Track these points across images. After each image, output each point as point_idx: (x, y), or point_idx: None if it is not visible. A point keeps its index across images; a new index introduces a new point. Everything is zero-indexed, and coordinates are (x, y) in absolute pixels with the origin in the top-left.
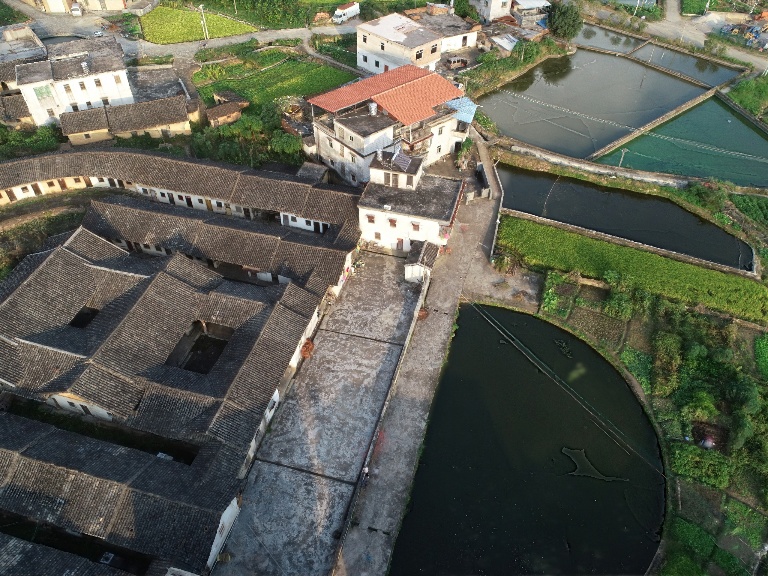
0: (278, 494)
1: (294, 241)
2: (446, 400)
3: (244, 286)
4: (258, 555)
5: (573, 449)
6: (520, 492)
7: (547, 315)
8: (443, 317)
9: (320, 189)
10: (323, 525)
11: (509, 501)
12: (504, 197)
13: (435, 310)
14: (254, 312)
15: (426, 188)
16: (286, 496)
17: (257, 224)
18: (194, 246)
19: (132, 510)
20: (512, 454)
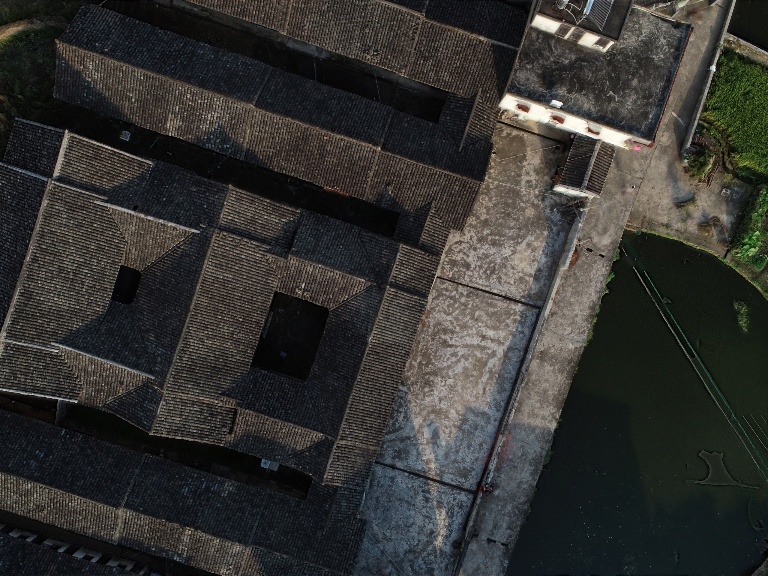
0: (395, 501)
1: (400, 147)
2: (583, 391)
3: (331, 228)
4: (381, 562)
5: (712, 452)
6: (644, 501)
7: (736, 262)
8: (597, 262)
9: (439, 23)
10: (442, 535)
11: (630, 511)
12: (736, 3)
13: (588, 249)
14: (354, 291)
15: (625, 46)
16: (404, 504)
17: (336, 91)
18: (246, 146)
19: (259, 560)
20: (645, 459)
